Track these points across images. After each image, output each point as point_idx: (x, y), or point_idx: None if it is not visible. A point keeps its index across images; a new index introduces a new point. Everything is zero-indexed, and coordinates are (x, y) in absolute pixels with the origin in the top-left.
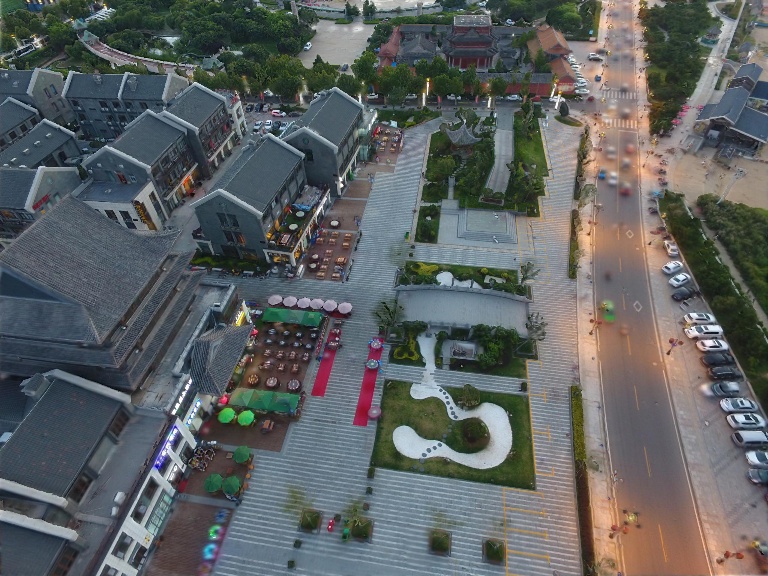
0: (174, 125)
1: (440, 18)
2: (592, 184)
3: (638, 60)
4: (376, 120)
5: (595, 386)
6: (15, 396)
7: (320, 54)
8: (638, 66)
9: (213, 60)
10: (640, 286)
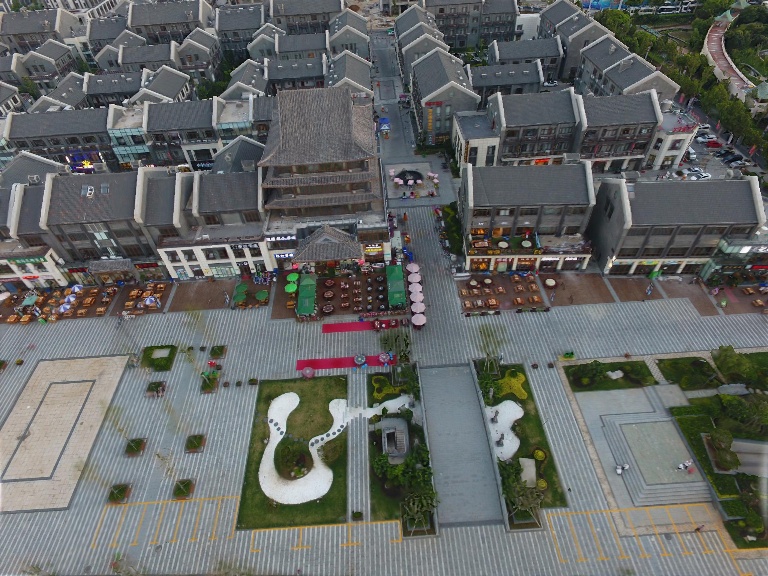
0: (576, 111)
1: None
2: None
3: None
4: None
5: None
6: (257, 167)
7: None
8: None
9: None
10: None
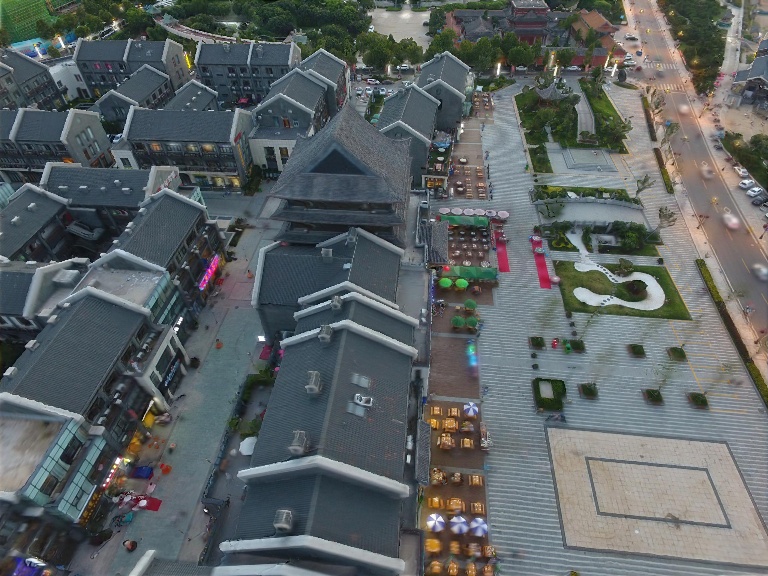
0: (317, 82)
1: (487, 5)
2: (676, 123)
3: (668, 39)
4: None
5: (713, 260)
6: None
7: None
8: (670, 44)
9: (303, 37)
10: (724, 198)
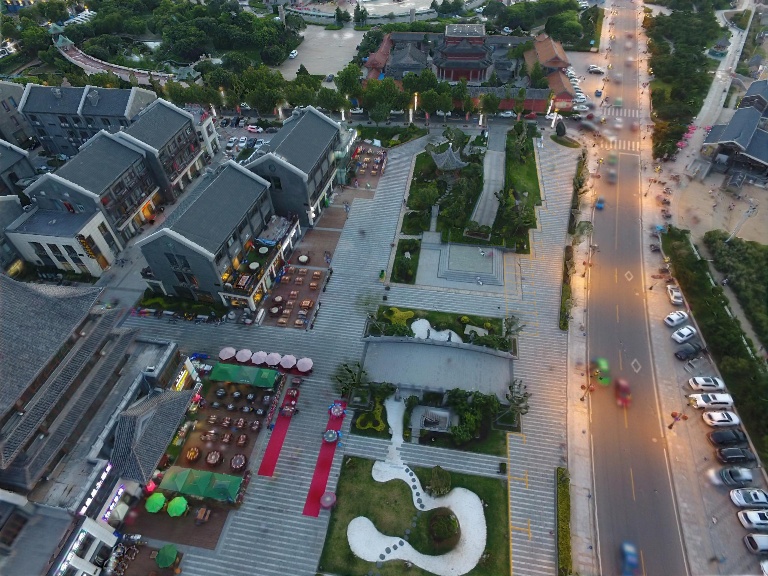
0: (131, 147)
1: (433, 25)
2: (587, 221)
3: (641, 73)
4: (358, 138)
5: (585, 468)
6: None
7: (306, 63)
8: (641, 80)
9: (189, 70)
10: (639, 340)
